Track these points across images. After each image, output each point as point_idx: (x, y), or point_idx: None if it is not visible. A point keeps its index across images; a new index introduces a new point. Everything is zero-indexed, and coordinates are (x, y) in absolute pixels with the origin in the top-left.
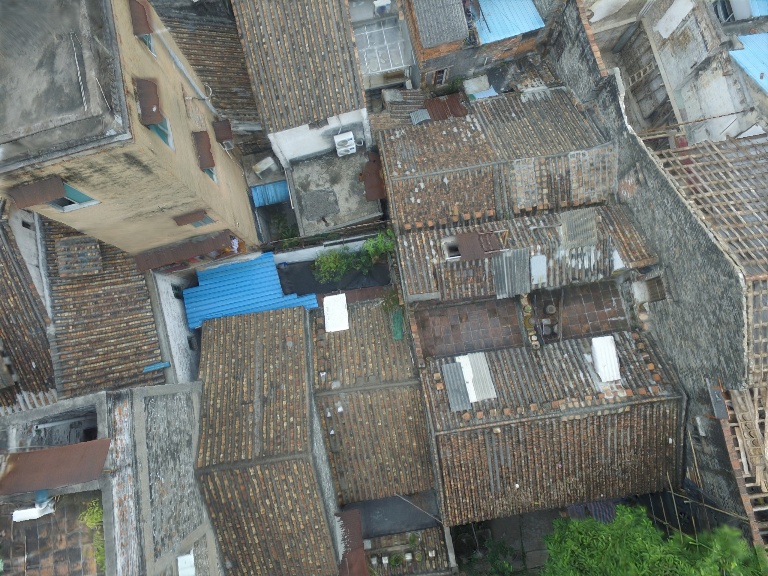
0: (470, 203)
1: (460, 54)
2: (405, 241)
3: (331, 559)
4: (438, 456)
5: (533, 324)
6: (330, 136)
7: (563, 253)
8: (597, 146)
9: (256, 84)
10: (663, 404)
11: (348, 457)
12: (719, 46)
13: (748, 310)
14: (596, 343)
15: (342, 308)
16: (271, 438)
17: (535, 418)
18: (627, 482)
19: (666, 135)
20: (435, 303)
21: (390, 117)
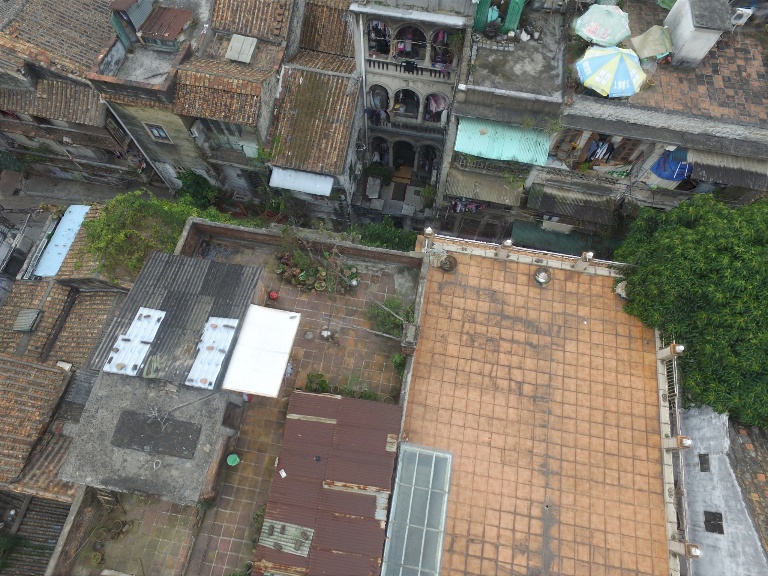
0: None
1: None
2: None
3: None
4: None
5: None
6: None
7: None
8: None
9: None
10: None
11: None
12: None
13: None
14: None
15: None
16: None
17: None
18: None
19: None
20: None
21: None
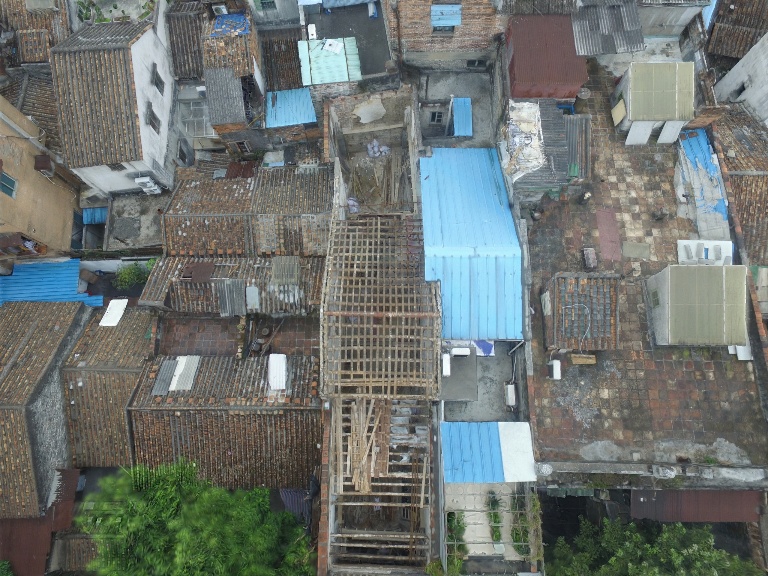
0: (225, 242)
1: (250, 132)
2: (161, 262)
3: (34, 501)
4: (130, 428)
5: (239, 339)
6: (134, 178)
7: (272, 288)
8: (323, 213)
9: (62, 133)
10: (311, 413)
11: (84, 426)
12: (419, 153)
13: (324, 336)
14: (272, 358)
15: (120, 310)
16: (4, 392)
17: (207, 408)
18: (284, 476)
19: (402, 214)
20: (183, 314)
21: (196, 171)
